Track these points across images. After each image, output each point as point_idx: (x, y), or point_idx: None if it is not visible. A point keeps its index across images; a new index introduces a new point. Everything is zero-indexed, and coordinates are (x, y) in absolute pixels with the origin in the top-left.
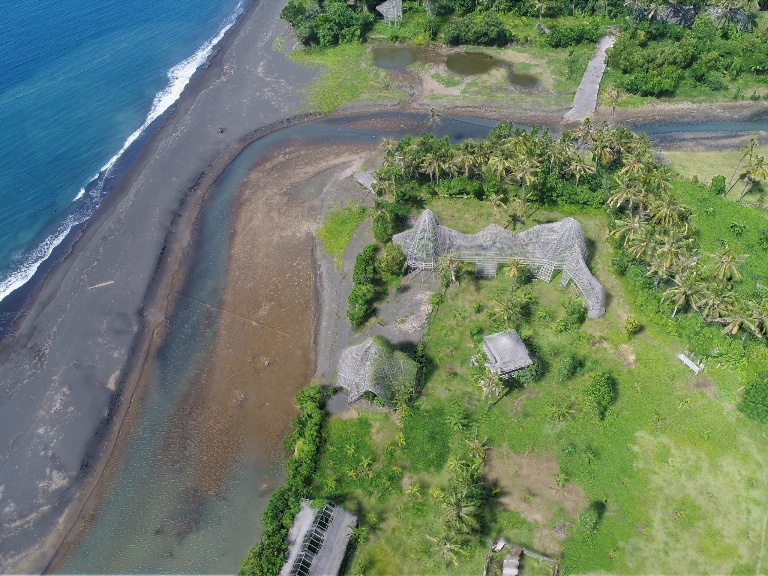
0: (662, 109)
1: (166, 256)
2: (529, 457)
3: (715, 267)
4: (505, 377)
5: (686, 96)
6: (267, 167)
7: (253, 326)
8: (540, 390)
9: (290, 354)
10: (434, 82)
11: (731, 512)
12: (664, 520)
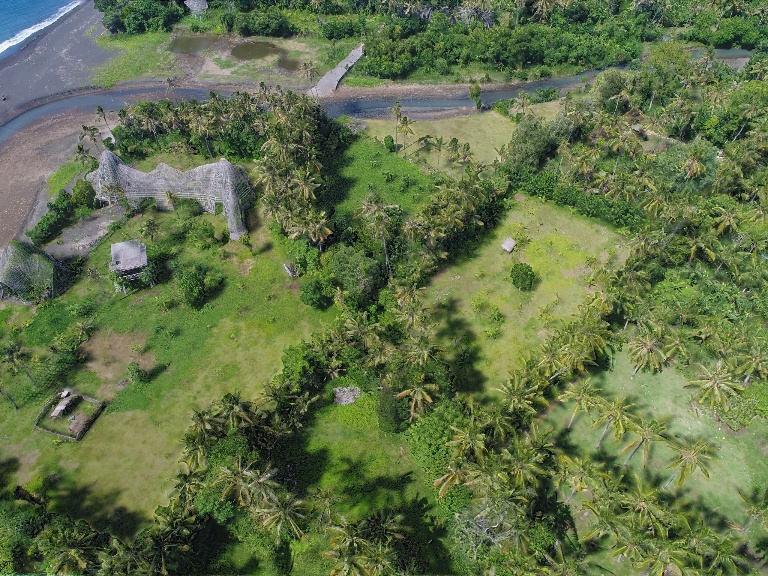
0: (392, 89)
1: None
2: (126, 335)
3: (299, 190)
4: (130, 278)
5: (416, 79)
6: (33, 128)
7: None
8: (162, 290)
9: None
10: (213, 64)
11: (262, 371)
12: (206, 377)
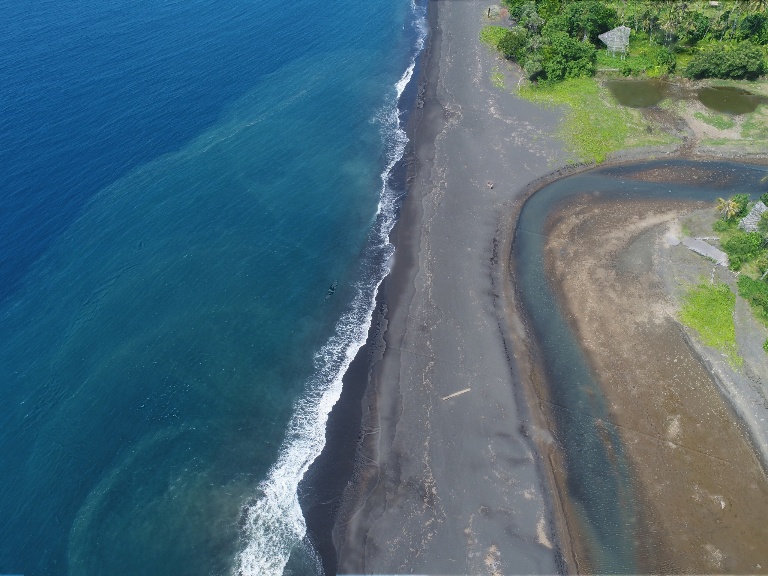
0: None
1: (510, 351)
2: None
3: None
4: None
5: None
6: (565, 231)
7: (673, 449)
8: None
9: (745, 490)
10: (701, 123)
11: None
12: None
